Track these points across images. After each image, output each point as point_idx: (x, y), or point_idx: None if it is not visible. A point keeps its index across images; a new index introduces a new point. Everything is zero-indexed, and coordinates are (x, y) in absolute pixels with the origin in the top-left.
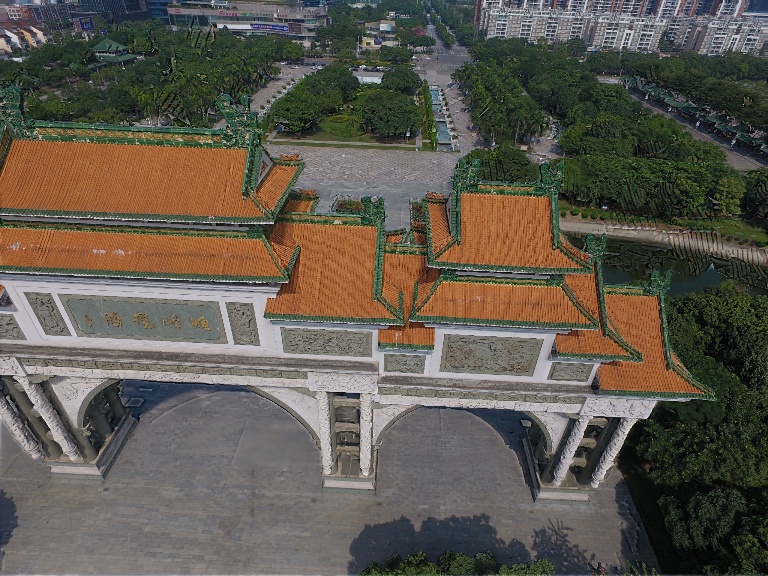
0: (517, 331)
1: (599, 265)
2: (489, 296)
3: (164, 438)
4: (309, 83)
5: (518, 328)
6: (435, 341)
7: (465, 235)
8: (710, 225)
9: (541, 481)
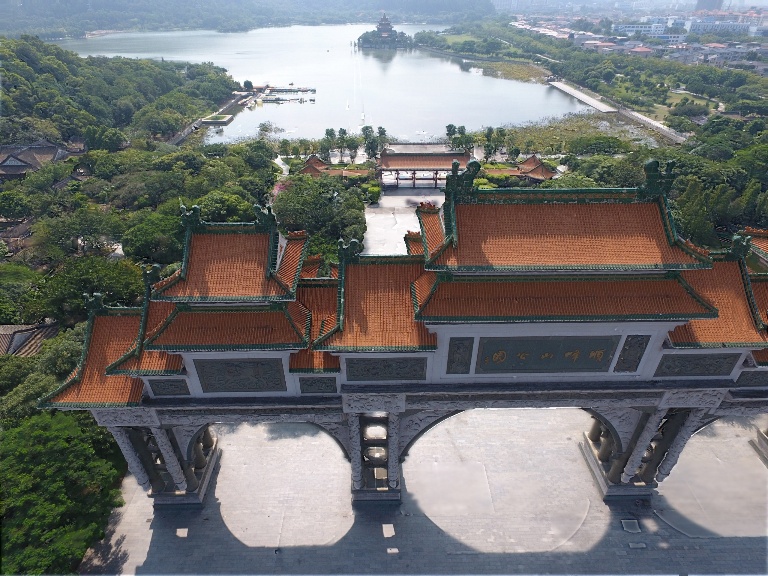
0: None
1: None
2: None
3: (562, 485)
4: None
5: None
6: None
7: None
8: None
9: (214, 441)
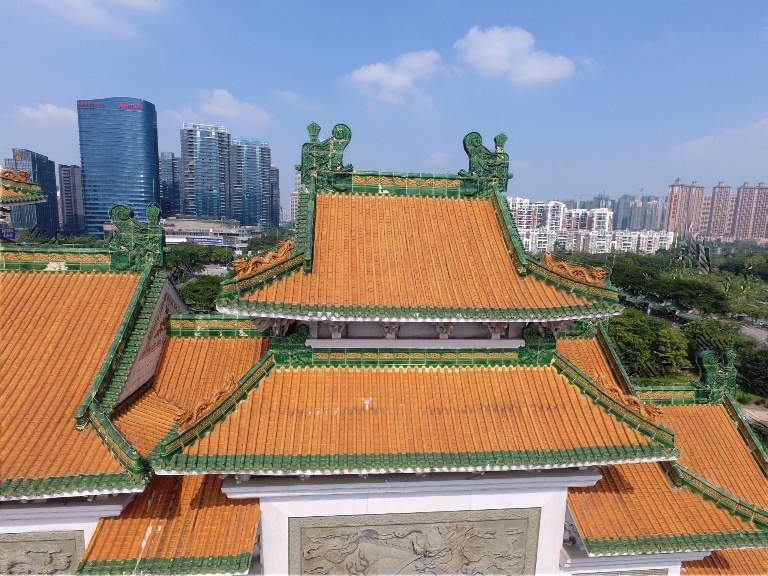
0: (473, 490)
1: (607, 340)
2: (391, 396)
3: None
4: (229, 273)
5: (474, 479)
6: (265, 542)
7: (324, 256)
8: (665, 381)
9: None
